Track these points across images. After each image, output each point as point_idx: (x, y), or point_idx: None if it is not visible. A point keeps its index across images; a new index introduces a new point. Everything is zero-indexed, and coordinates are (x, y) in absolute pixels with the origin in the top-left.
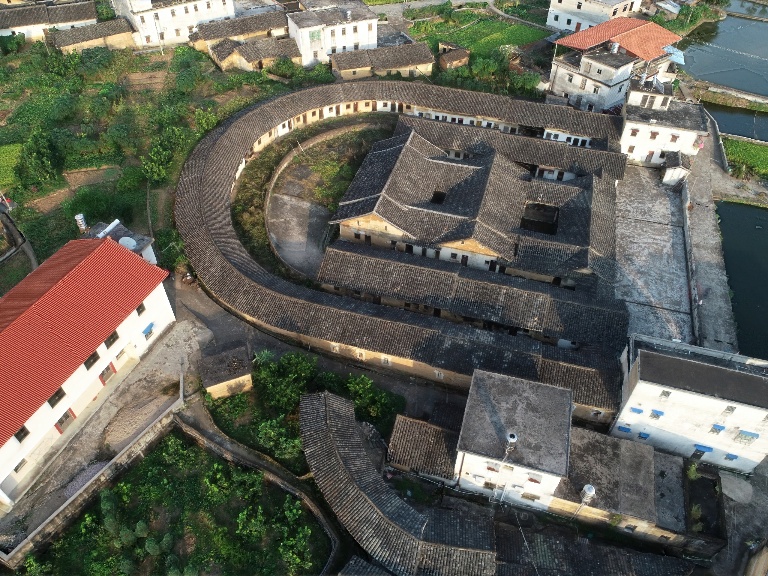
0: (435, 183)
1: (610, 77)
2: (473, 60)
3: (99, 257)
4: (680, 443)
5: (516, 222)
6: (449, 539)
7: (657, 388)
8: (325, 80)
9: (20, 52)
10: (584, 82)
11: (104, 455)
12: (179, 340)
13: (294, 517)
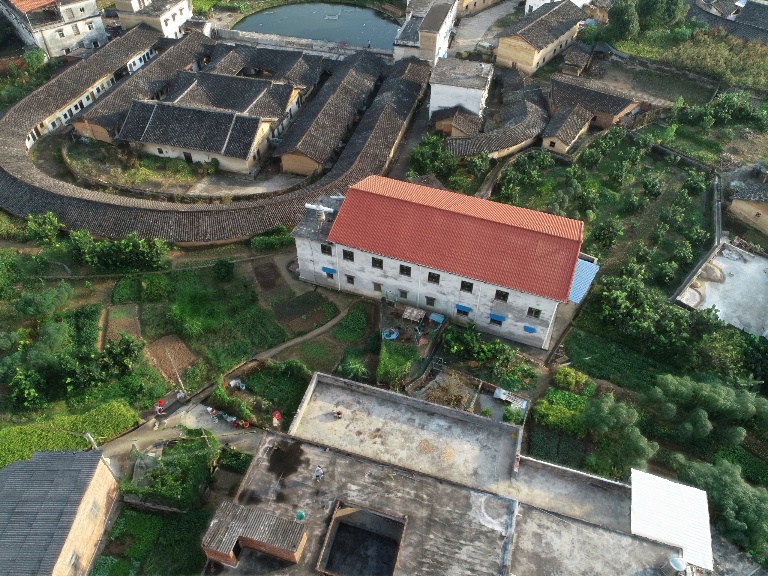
0: None
1: (94, 8)
2: None
3: None
4: None
5: None
6: (522, 112)
7: None
8: None
9: None
10: (75, 28)
11: None
12: None
13: None
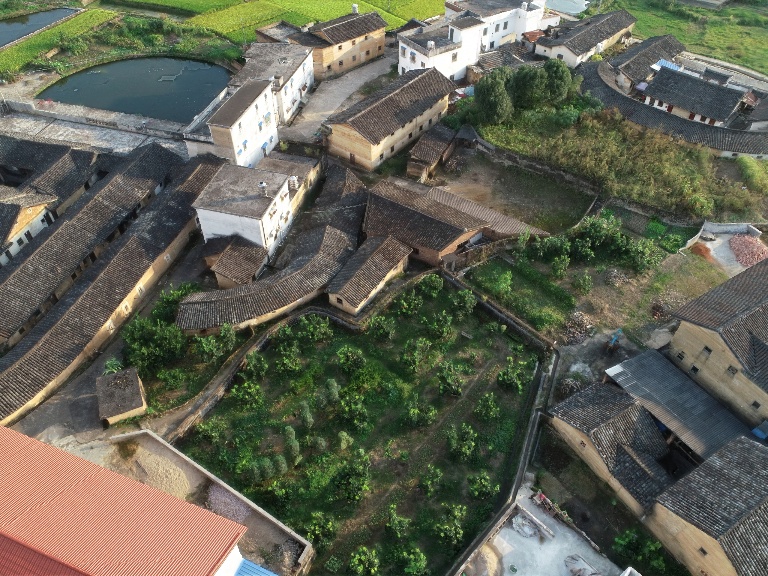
0: None
1: None
2: None
3: None
4: (258, 154)
5: (6, 188)
6: (316, 246)
7: (237, 124)
8: None
9: None
10: None
11: (201, 496)
12: None
13: None
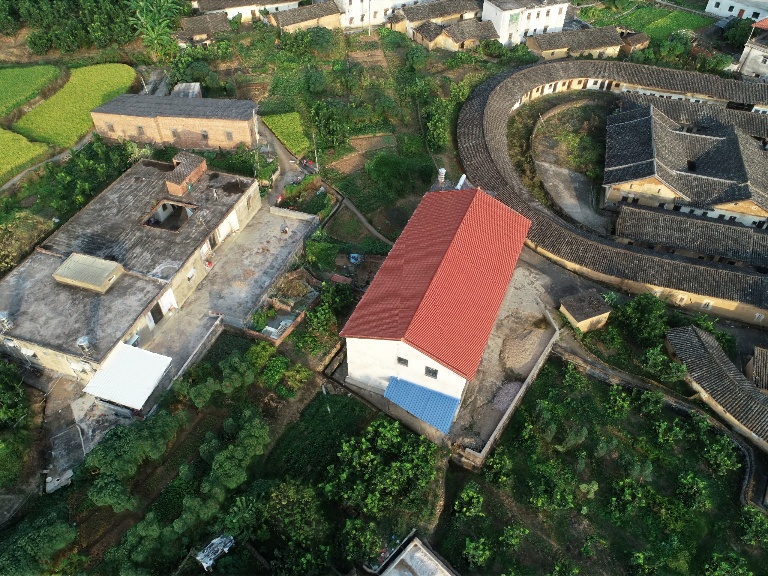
0: (684, 152)
1: None
2: (651, 43)
3: (479, 205)
4: None
5: None
6: None
7: None
8: (530, 60)
9: (250, 31)
10: None
11: (512, 377)
12: (524, 284)
13: (705, 428)
